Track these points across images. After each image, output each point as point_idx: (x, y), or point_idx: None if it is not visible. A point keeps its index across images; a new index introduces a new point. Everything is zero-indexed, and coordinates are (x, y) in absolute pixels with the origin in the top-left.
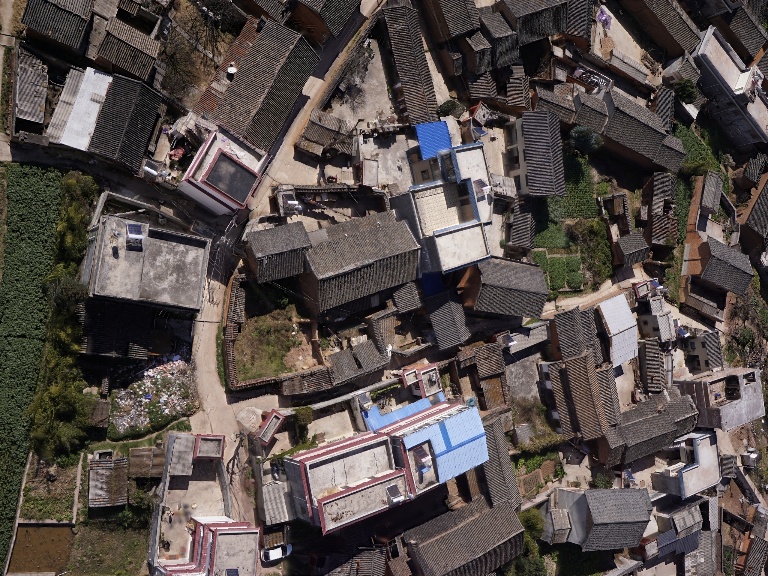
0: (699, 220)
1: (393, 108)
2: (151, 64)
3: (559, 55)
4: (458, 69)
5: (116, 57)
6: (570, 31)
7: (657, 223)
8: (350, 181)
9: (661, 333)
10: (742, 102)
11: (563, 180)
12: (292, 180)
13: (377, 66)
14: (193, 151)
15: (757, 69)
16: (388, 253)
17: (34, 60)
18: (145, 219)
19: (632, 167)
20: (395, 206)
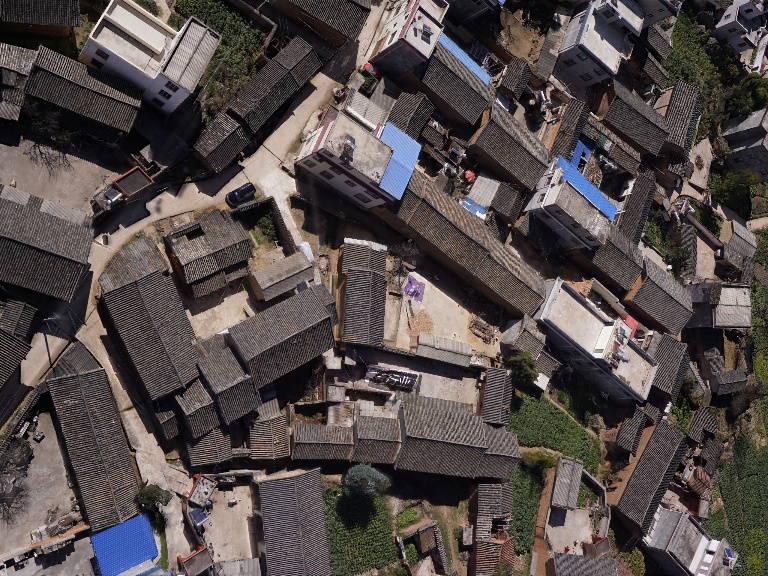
0: (555, 513)
1: (75, 499)
2: None
3: (335, 367)
4: (172, 430)
5: None
6: (347, 338)
7: (482, 552)
8: None
9: None
10: (604, 365)
11: (326, 554)
12: None
13: (50, 447)
14: None
15: (622, 323)
16: None
17: None
18: None
19: None
20: None
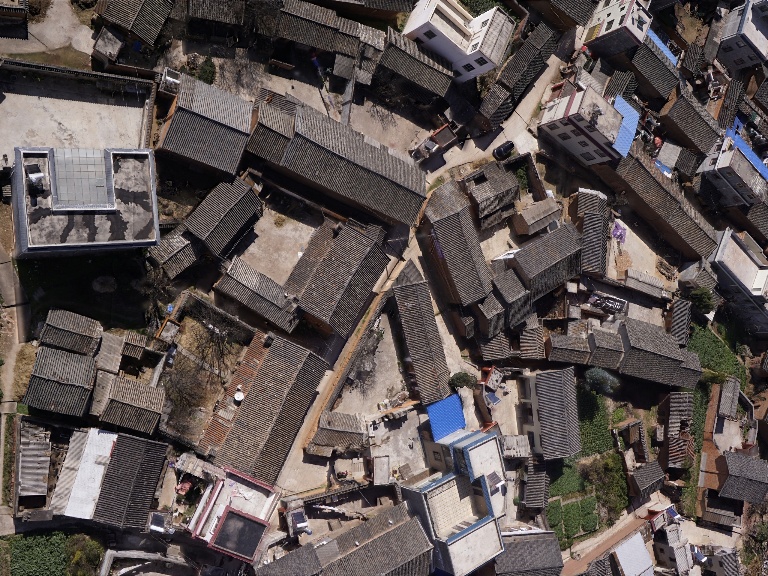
0: None
1: (404, 381)
2: (156, 419)
3: (573, 291)
4: (470, 332)
5: (120, 419)
6: (584, 267)
7: (674, 446)
8: (361, 472)
9: (678, 565)
10: (760, 301)
11: (578, 434)
12: (301, 484)
13: (387, 341)
14: (200, 483)
15: None
16: (400, 561)
17: (37, 430)
18: (152, 565)
19: (648, 384)
20: (407, 497)
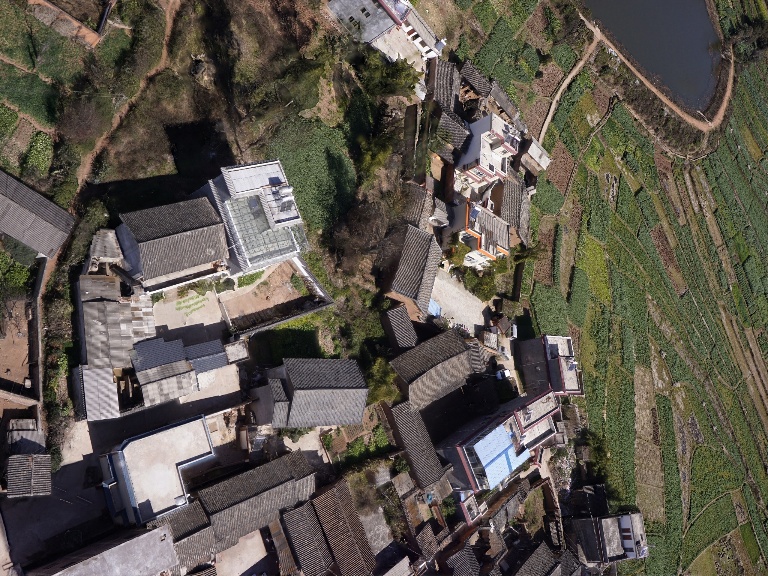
0: None
1: None
2: None
3: None
4: None
5: None
6: None
7: None
8: None
9: None
10: None
11: None
12: None
13: None
14: None
15: None
16: None
17: None
18: (592, 572)
19: None
20: None
